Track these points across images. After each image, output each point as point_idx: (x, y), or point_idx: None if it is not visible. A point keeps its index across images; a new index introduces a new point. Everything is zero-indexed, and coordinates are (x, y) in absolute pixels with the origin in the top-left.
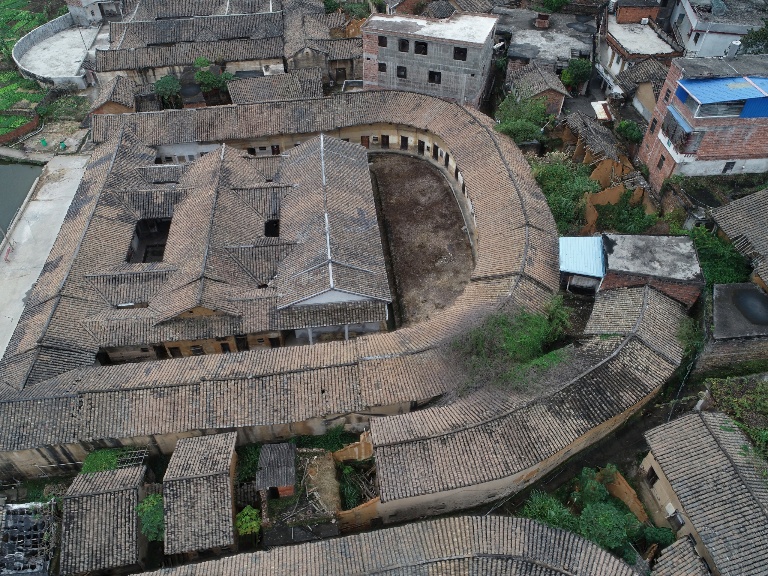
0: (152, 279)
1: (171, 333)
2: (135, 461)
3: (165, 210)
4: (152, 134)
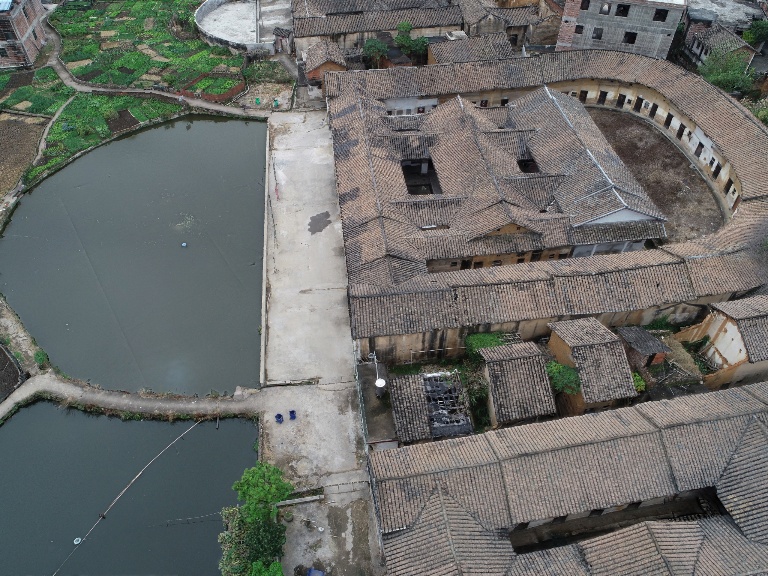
0: (447, 205)
1: (483, 248)
2: (516, 340)
3: (422, 152)
4: (380, 89)
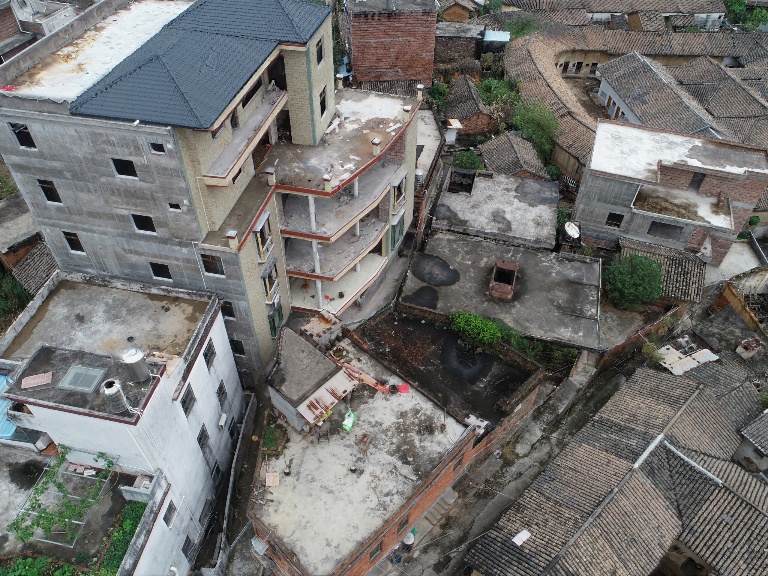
0: None
1: None
2: (680, 31)
3: None
4: None
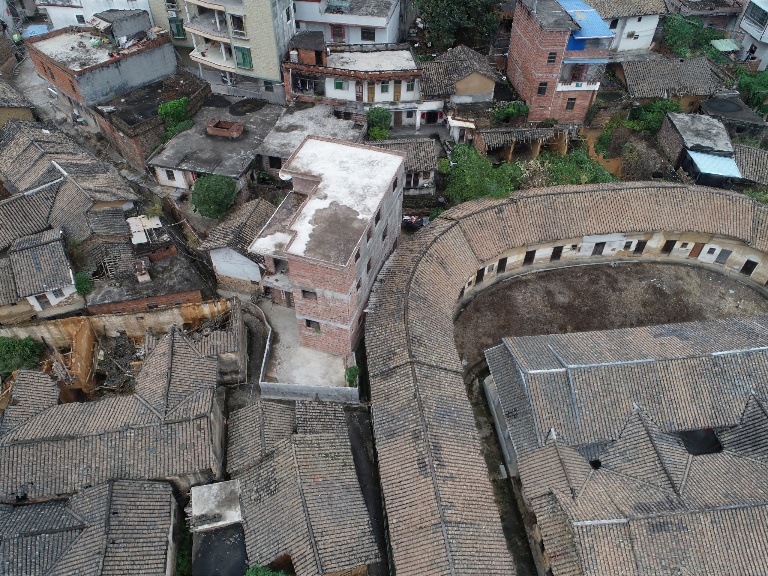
0: None
1: None
2: None
3: None
4: None
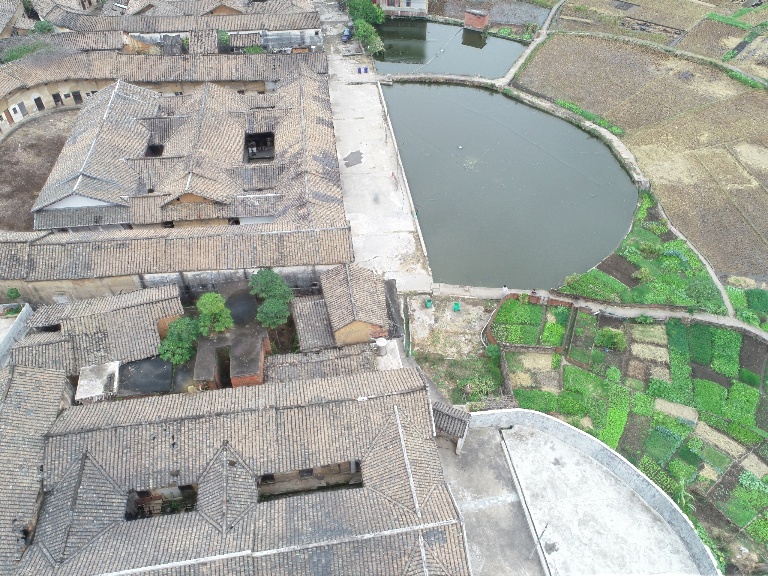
0: None
1: None
2: (238, 52)
3: None
4: None
